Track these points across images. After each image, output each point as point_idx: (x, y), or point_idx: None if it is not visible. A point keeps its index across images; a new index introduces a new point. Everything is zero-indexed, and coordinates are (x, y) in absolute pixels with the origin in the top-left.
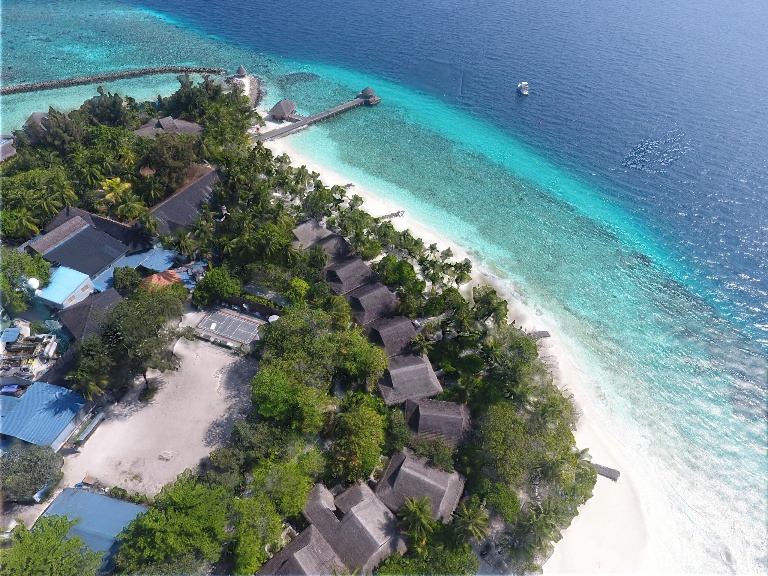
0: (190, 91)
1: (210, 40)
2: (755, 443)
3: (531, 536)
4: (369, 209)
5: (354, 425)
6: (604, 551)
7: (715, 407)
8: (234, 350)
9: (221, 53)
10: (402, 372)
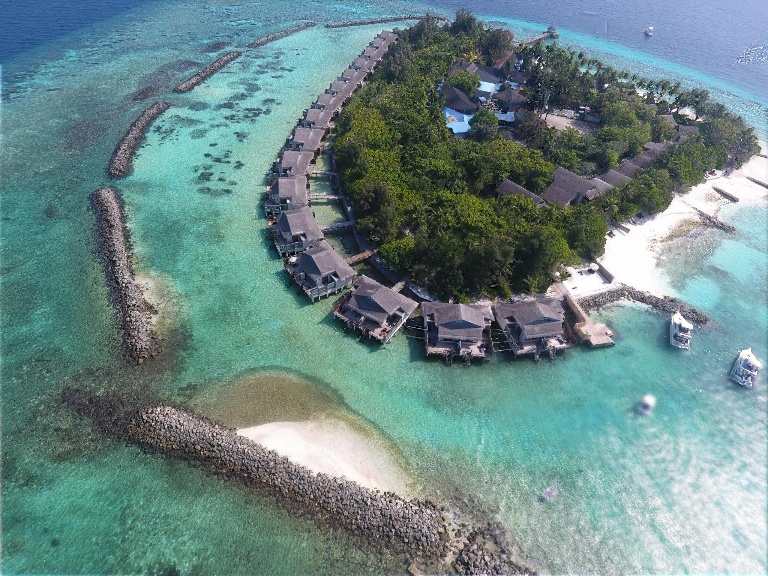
0: (470, 18)
1: (418, 3)
2: None
3: None
4: None
5: (660, 119)
6: (767, 171)
7: None
8: (571, 116)
9: (433, 10)
10: None
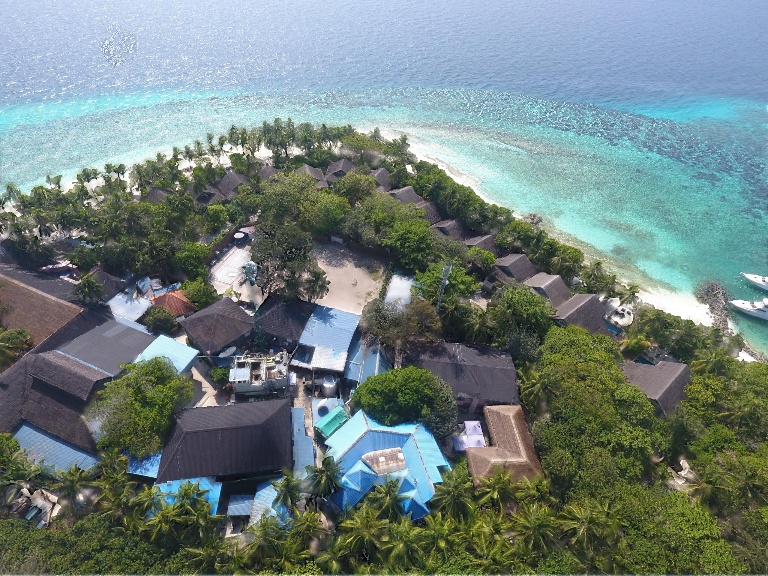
0: None
1: None
2: (346, 111)
3: (406, 146)
4: (89, 191)
5: None
6: None
7: (327, 113)
8: None
9: None
10: (311, 173)
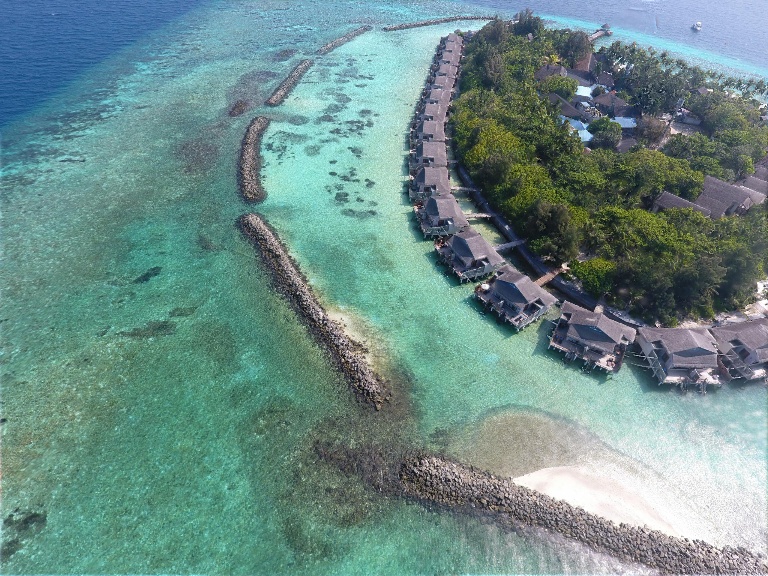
0: (536, 19)
1: None
2: None
3: None
4: None
5: None
6: None
7: None
8: None
9: (478, 9)
10: (766, 117)
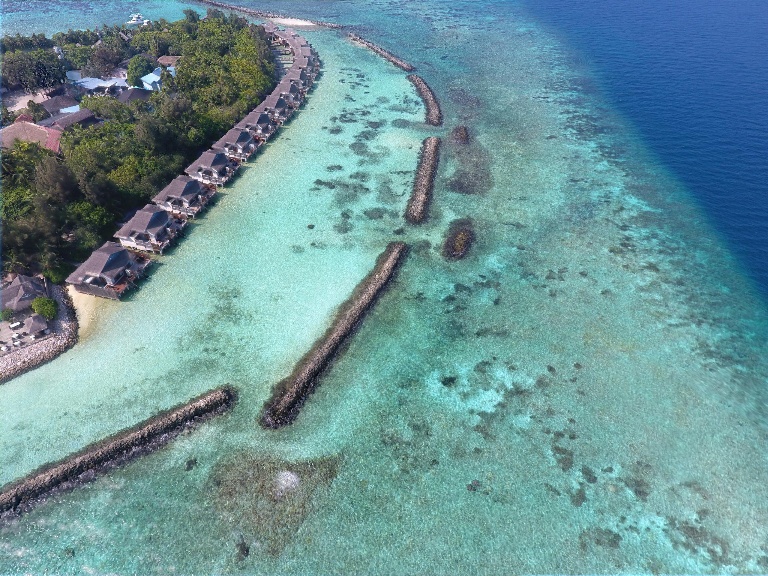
0: None
1: None
2: None
3: None
4: None
5: None
6: None
7: None
8: None
9: None
10: None
